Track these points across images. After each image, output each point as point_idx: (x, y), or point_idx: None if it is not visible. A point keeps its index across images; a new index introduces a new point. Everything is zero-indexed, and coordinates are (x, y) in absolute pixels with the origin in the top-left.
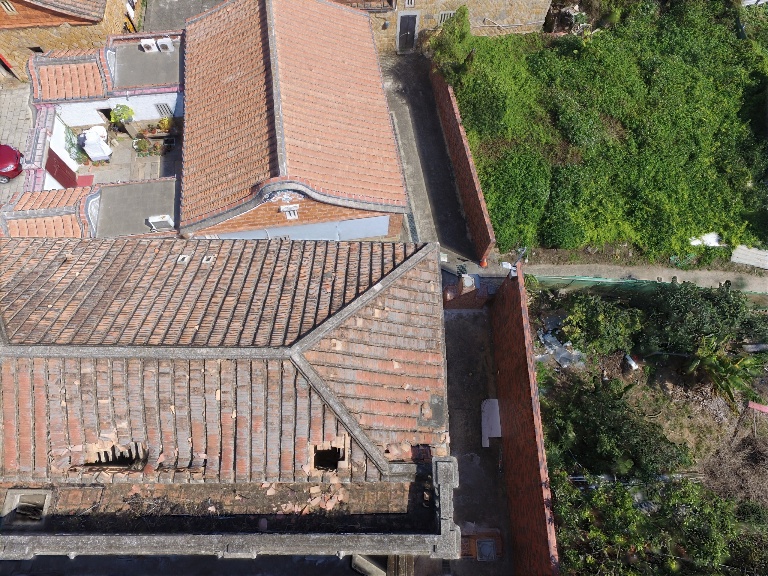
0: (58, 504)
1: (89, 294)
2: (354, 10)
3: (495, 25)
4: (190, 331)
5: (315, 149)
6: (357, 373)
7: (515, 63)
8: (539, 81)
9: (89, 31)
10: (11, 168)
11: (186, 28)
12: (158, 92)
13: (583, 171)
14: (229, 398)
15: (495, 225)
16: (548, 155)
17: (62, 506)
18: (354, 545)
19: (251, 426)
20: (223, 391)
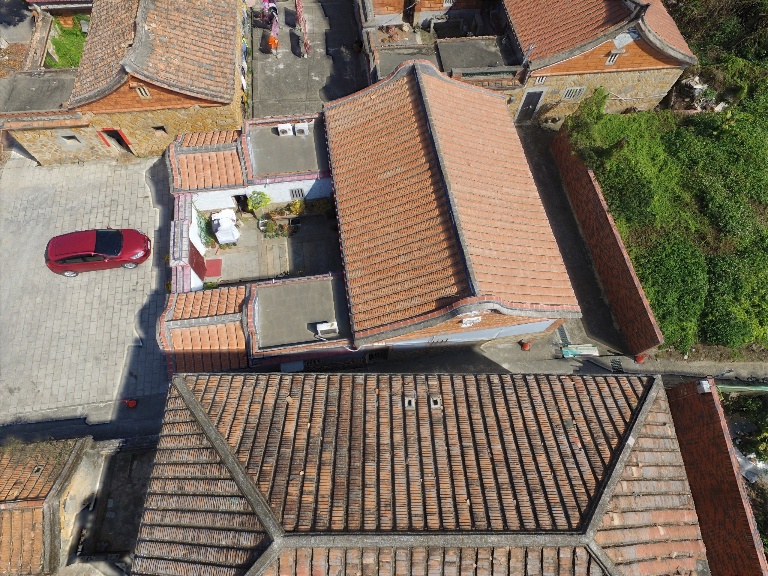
0: None
1: (334, 454)
2: (492, 92)
3: (618, 98)
4: (464, 508)
5: (491, 256)
6: (636, 549)
7: (650, 143)
8: (679, 163)
9: (217, 111)
10: (141, 254)
11: (325, 113)
12: (298, 179)
13: (742, 264)
14: None
15: (657, 322)
16: (699, 244)
17: None
18: None
19: None
20: None
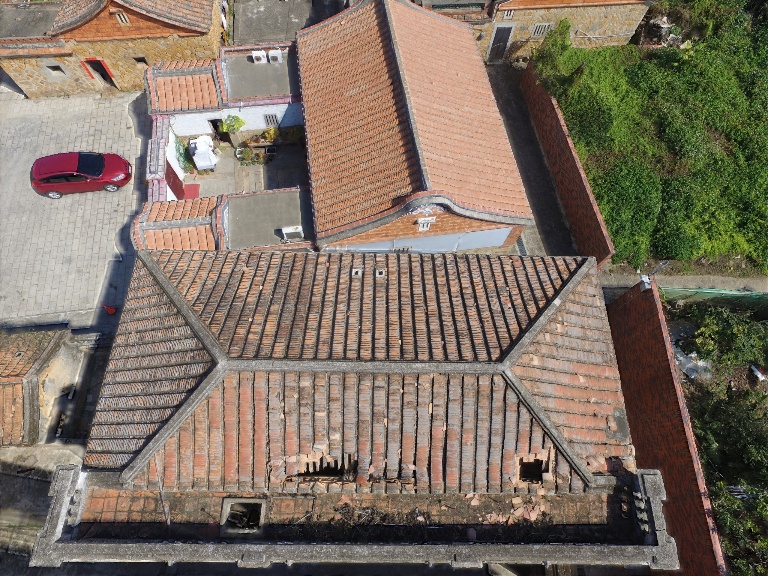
0: (272, 513)
1: (281, 308)
2: (459, 23)
3: (586, 36)
4: (395, 346)
5: (447, 162)
6: (554, 387)
7: (614, 75)
8: (640, 93)
9: (195, 42)
10: (122, 177)
11: (298, 40)
12: (271, 103)
13: (694, 183)
14: (441, 411)
15: (610, 236)
16: (655, 167)
17: (276, 515)
18: (575, 555)
19: (462, 439)
20: (435, 405)
